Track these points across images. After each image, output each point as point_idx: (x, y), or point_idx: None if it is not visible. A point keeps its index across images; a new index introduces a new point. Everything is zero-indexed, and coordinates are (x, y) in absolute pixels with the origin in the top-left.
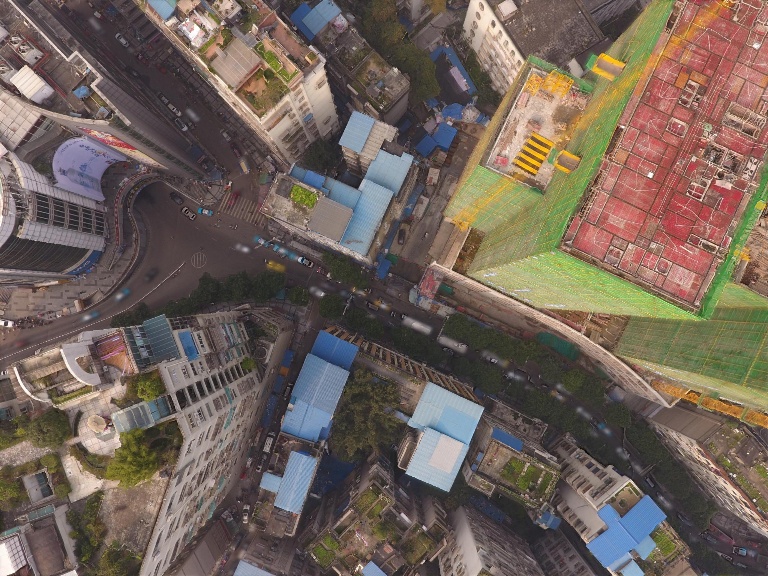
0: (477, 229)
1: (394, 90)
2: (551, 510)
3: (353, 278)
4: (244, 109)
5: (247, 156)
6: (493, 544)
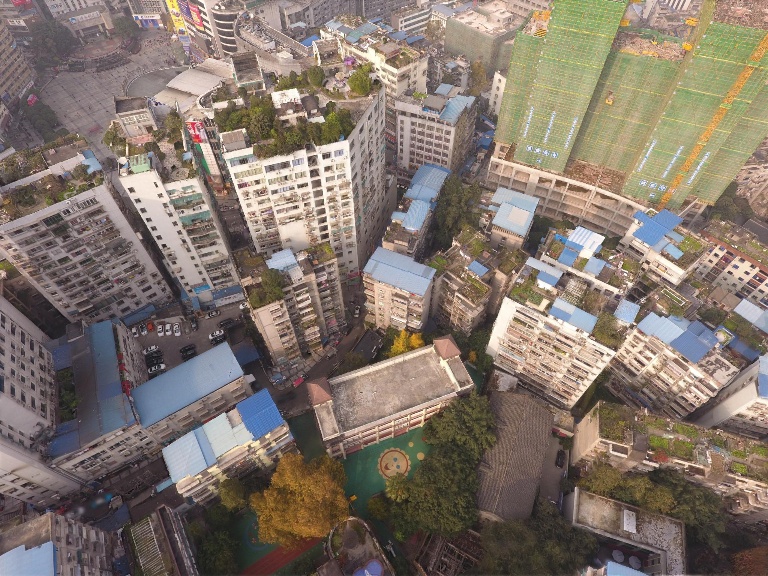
0: (515, 145)
1: None
2: None
3: None
4: (388, 71)
5: None
6: None
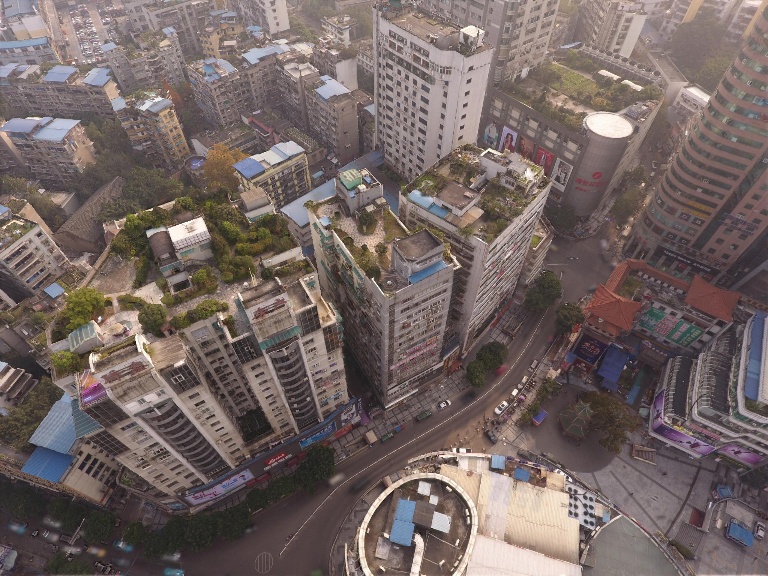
0: None
1: None
2: None
3: (63, 567)
4: None
5: None
6: None
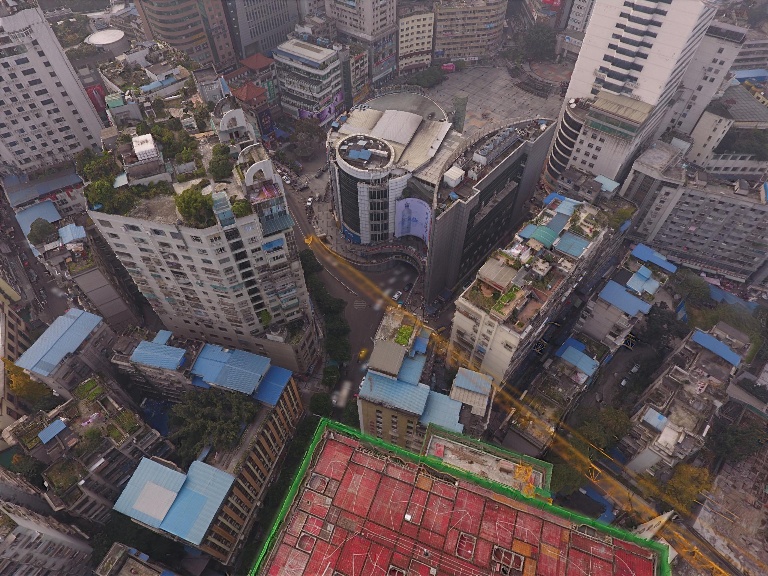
0: None
1: (532, 430)
2: None
3: (349, 421)
4: None
5: None
6: (38, 571)
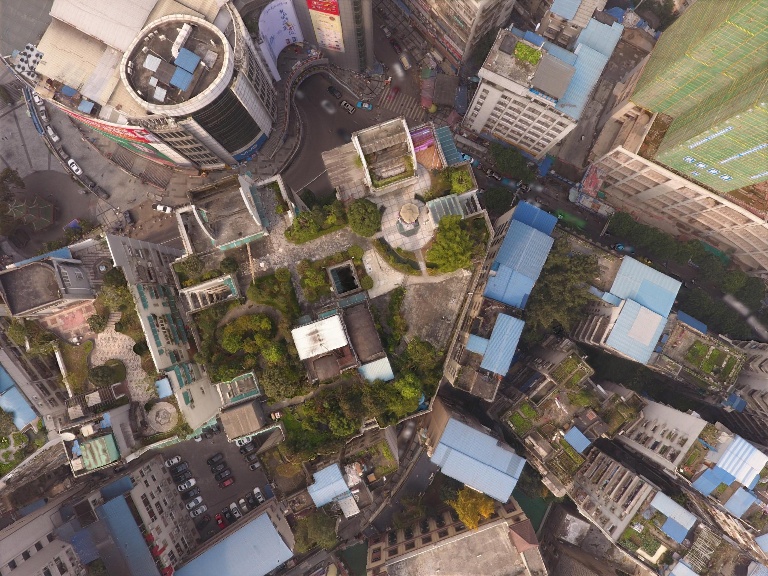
0: (663, 115)
1: None
2: (737, 392)
3: (521, 170)
4: None
5: (407, 53)
6: None
